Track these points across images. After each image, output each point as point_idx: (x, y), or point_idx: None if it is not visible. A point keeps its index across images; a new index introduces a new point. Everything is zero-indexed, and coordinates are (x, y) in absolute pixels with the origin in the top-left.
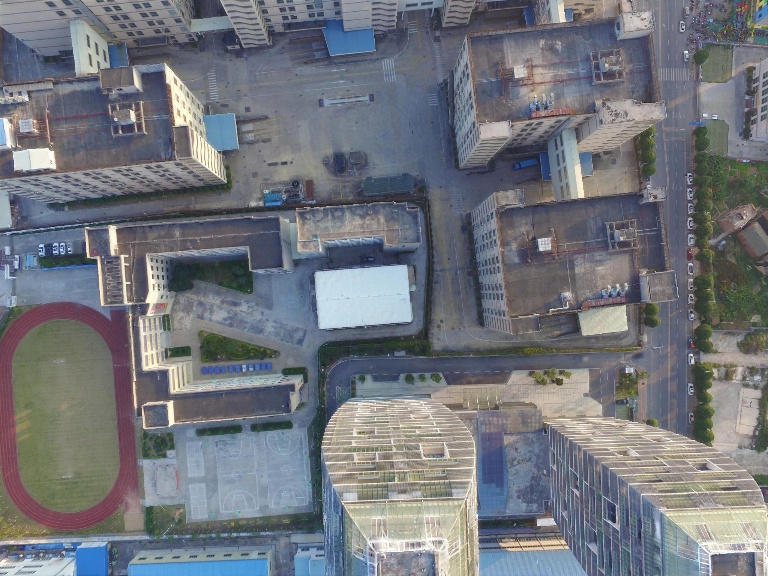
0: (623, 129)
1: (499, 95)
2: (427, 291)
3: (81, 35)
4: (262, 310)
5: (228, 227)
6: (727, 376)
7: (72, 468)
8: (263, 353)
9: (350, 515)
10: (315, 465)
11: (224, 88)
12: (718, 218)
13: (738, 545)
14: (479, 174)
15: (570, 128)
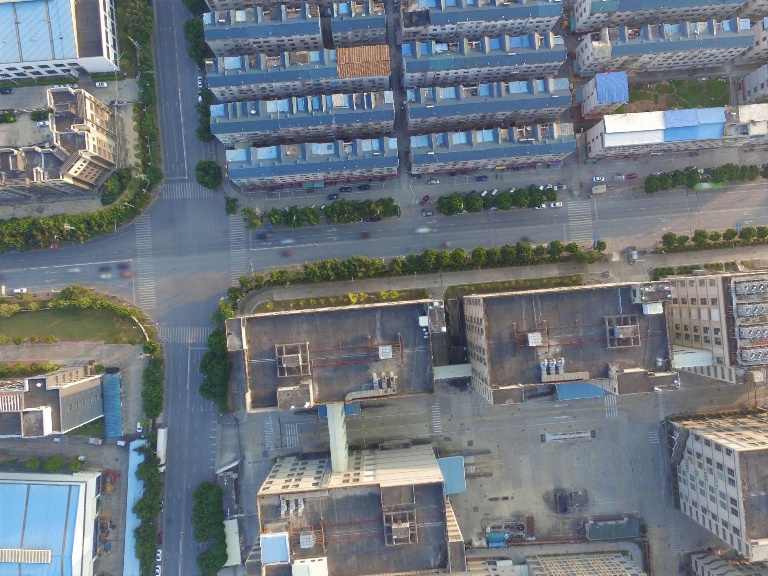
0: None
1: (767, 509)
2: None
3: (337, 411)
4: None
5: None
6: None
7: None
8: None
9: None
10: None
11: (448, 421)
12: None
13: None
14: None
15: None
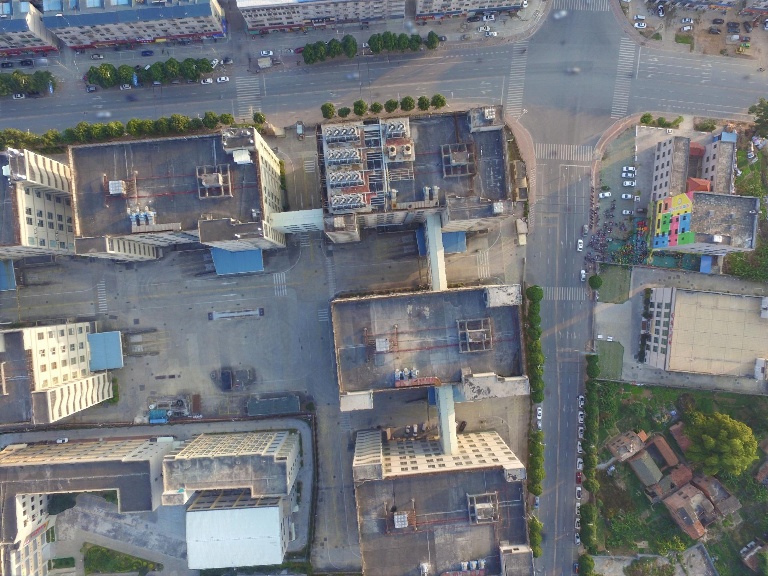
0: None
1: (364, 362)
2: (311, 509)
3: None
4: (146, 523)
5: (99, 468)
6: None
7: None
8: (143, 572)
9: None
10: None
11: (113, 300)
12: (609, 442)
13: None
14: None
15: None
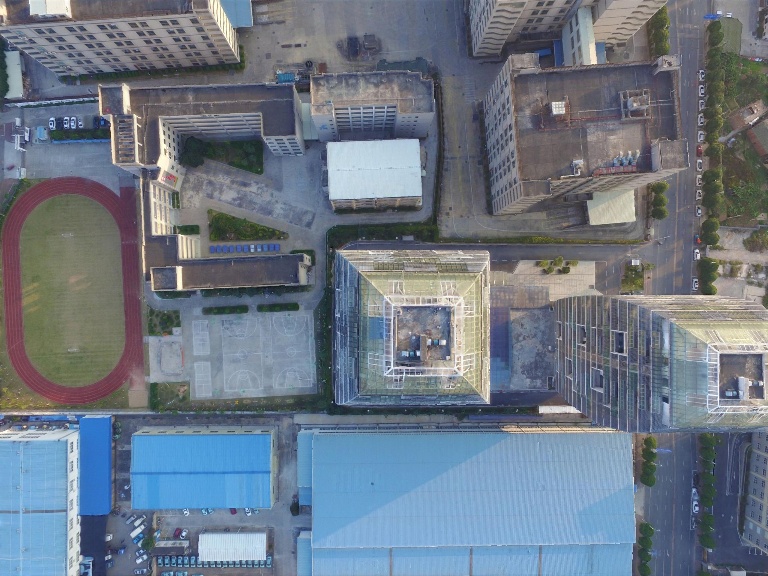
0: (639, 3)
1: None
2: (437, 178)
3: None
4: (272, 191)
5: (241, 93)
6: (732, 272)
7: (78, 343)
8: (272, 231)
9: (367, 278)
10: (320, 347)
11: None
12: (729, 116)
13: (747, 347)
14: (492, 63)
15: (586, 6)
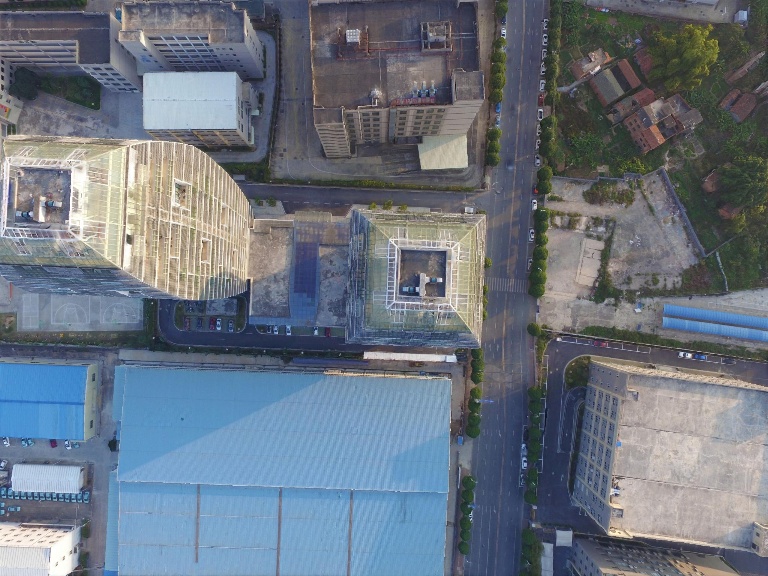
0: None
1: None
2: (272, 119)
3: None
4: (107, 127)
5: (59, 21)
6: (570, 224)
7: None
8: None
9: (4, 144)
10: None
11: None
12: (572, 66)
13: (429, 243)
14: None
15: None
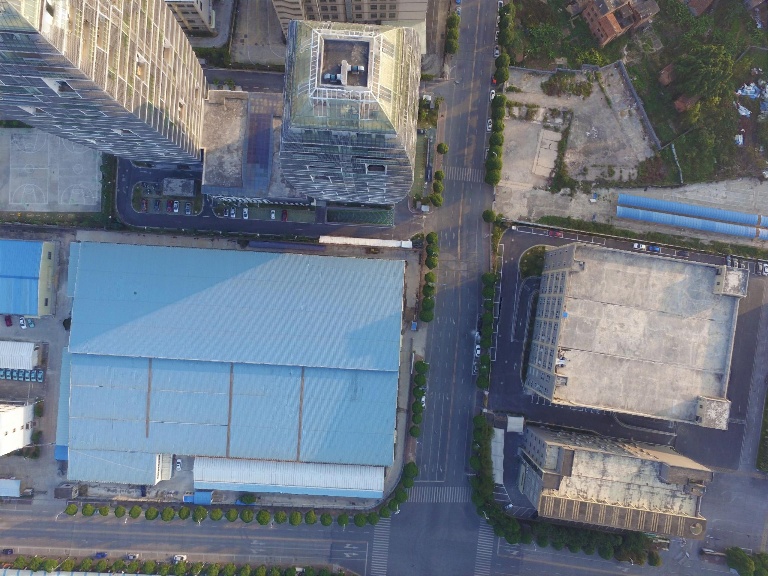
0: None
1: None
2: (233, 4)
3: None
4: None
5: None
6: (527, 115)
7: None
8: None
9: None
10: None
11: None
12: None
13: (352, 33)
14: None
15: None
